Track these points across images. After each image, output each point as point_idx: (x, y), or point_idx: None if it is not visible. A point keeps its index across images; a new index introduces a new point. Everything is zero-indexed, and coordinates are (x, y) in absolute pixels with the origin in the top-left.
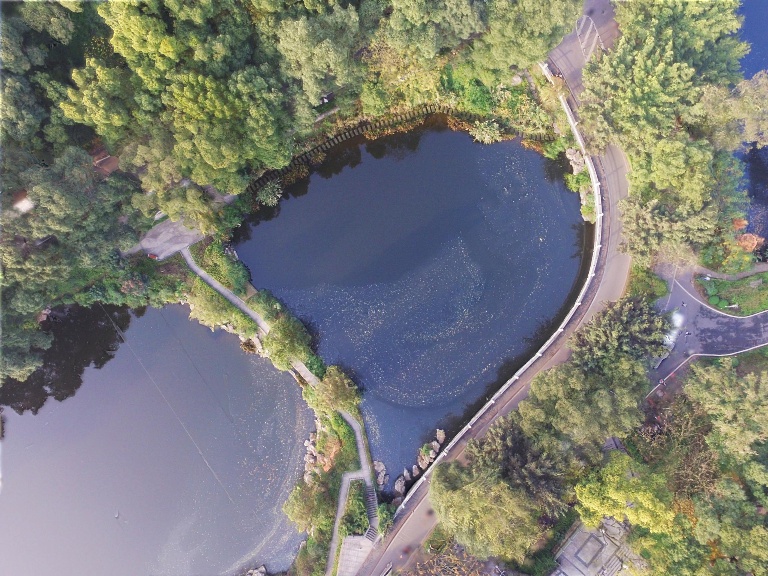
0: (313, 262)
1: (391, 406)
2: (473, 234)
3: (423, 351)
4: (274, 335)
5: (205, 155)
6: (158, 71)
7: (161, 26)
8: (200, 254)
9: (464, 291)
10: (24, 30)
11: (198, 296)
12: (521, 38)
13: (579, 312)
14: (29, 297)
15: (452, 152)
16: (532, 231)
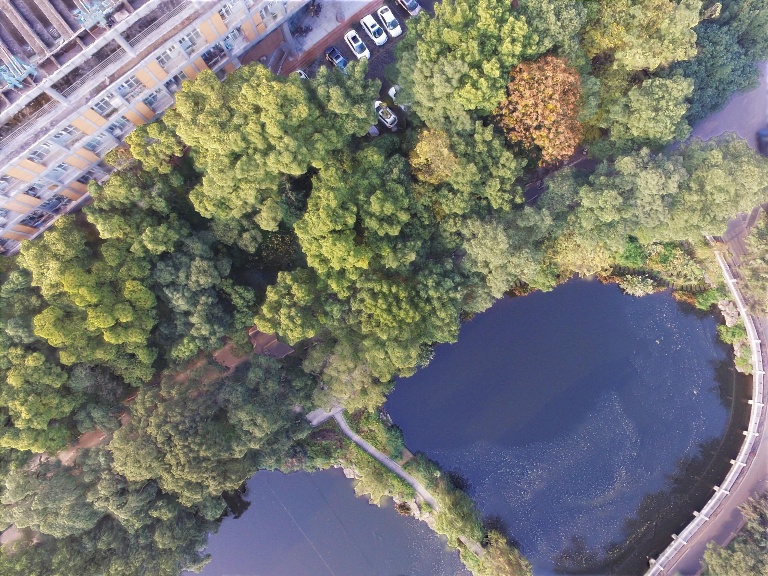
0: (467, 423)
1: (551, 568)
2: (627, 389)
3: (581, 511)
4: (453, 522)
5: (396, 361)
6: (349, 279)
7: (353, 236)
8: (355, 420)
9: (620, 448)
10: (212, 241)
11: (354, 462)
12: (703, 223)
13: (742, 471)
14: (216, 503)
15: (602, 305)
16: (686, 384)
